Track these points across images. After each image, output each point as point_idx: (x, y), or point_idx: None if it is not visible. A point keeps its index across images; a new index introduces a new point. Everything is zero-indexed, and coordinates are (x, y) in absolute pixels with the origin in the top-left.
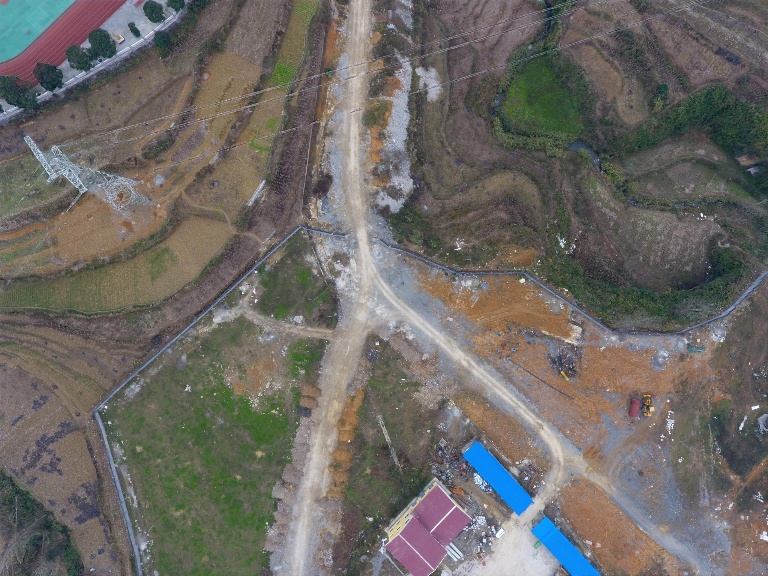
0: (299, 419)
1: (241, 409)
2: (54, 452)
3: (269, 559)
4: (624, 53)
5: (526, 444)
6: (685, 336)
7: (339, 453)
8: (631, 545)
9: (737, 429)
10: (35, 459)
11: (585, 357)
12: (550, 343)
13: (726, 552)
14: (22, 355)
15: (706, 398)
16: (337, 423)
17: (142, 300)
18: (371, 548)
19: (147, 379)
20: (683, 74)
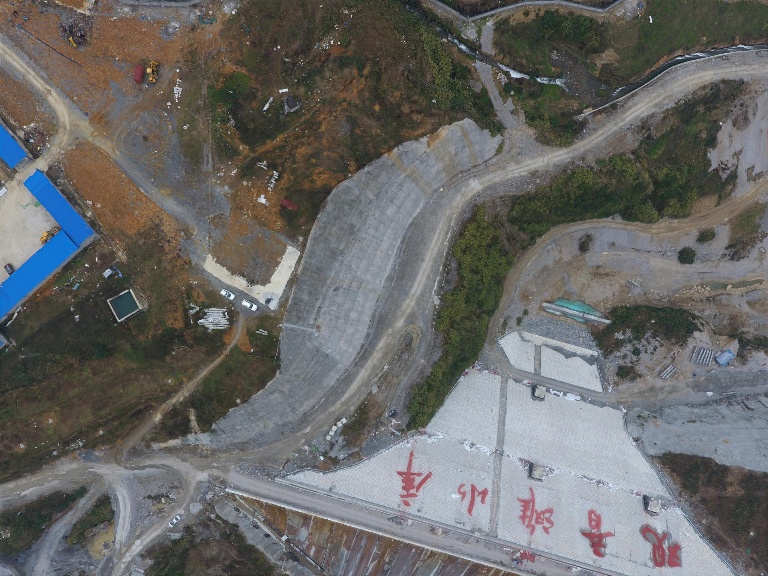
0: None
1: None
2: None
3: None
4: None
5: (34, 109)
6: (197, 8)
7: None
8: (131, 206)
9: (261, 109)
10: None
11: (96, 26)
12: (63, 13)
13: (225, 215)
14: None
15: (215, 68)
16: None
17: None
18: None
19: None
20: None
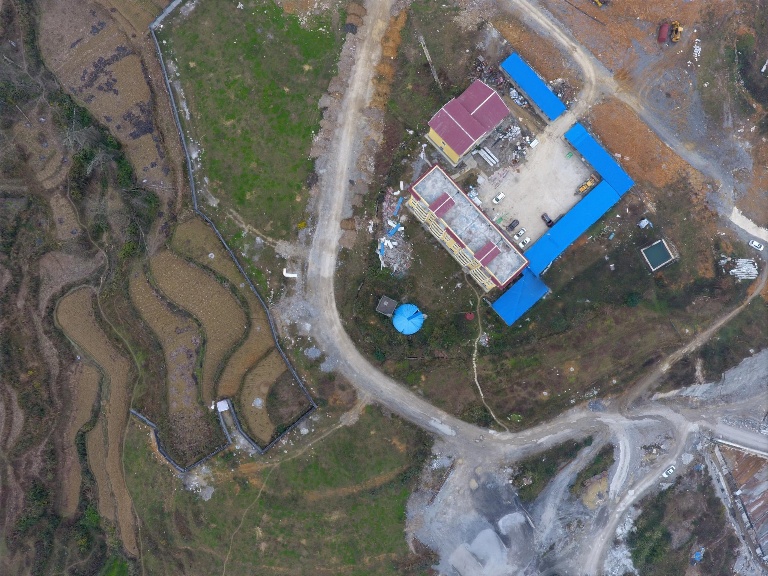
0: (345, 35)
1: (290, 26)
2: (110, 73)
3: (314, 164)
4: None
5: (560, 64)
6: None
7: (383, 65)
8: (658, 159)
9: (759, 70)
10: (92, 79)
11: None
12: None
13: (748, 169)
14: None
15: (731, 29)
16: (381, 40)
17: None
18: (412, 152)
19: None
20: None
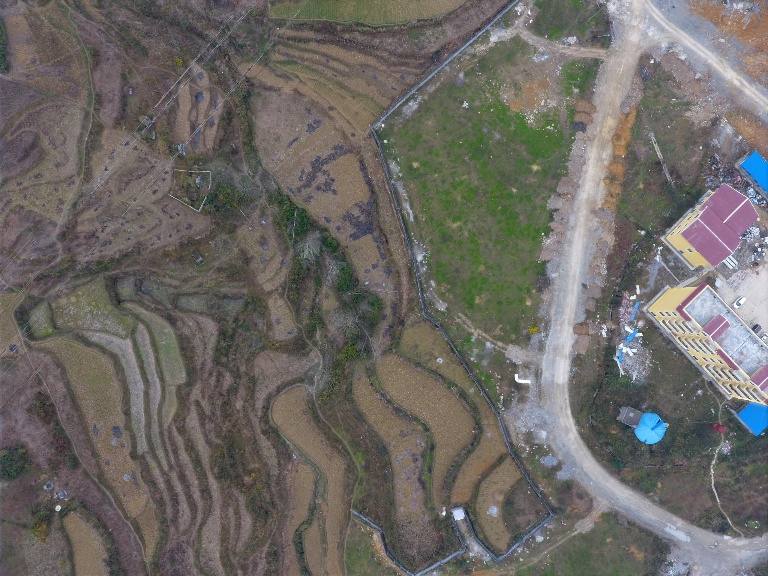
0: (575, 134)
1: (517, 125)
2: (328, 173)
3: (546, 267)
4: None
5: None
6: None
7: (615, 165)
8: None
9: None
10: (310, 179)
11: None
12: None
13: None
14: (302, 75)
15: None
16: (612, 138)
17: (426, 14)
18: (647, 255)
19: (425, 96)
20: None
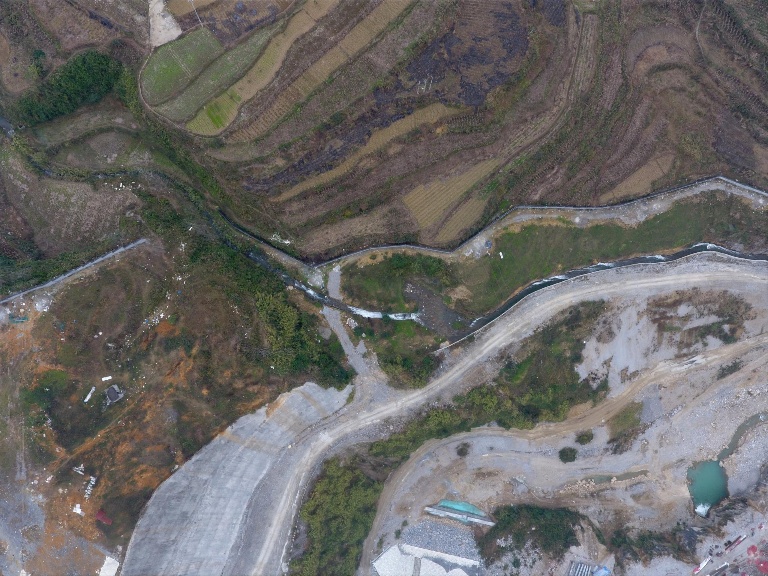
0: None
1: None
2: None
3: None
4: (3, 19)
5: None
6: (8, 306)
7: None
8: None
9: (82, 401)
10: None
11: None
12: None
13: (39, 526)
14: None
15: (27, 369)
16: None
17: None
18: None
19: None
20: (55, 39)
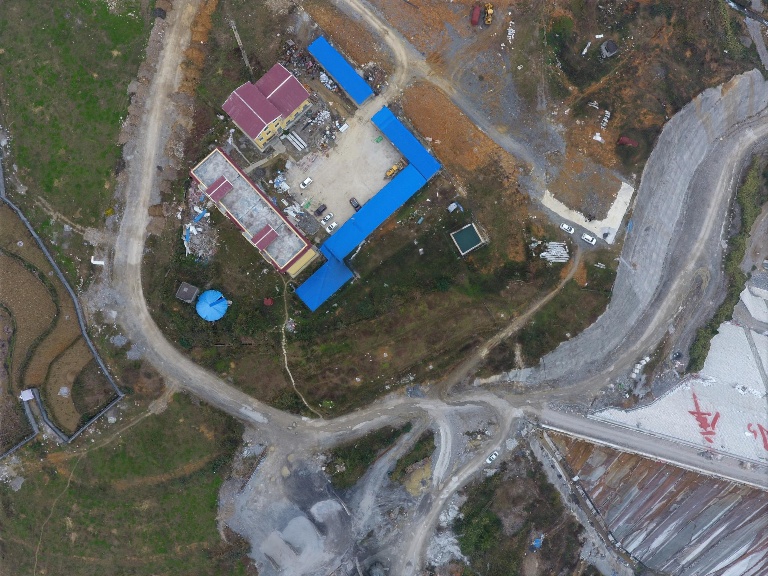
0: (154, 20)
1: (99, 11)
2: None
3: (122, 150)
4: None
5: (371, 48)
6: None
7: (191, 50)
8: (469, 143)
9: (580, 53)
10: None
11: None
12: None
13: (561, 152)
14: None
15: (546, 11)
16: (190, 25)
17: None
18: (219, 138)
19: None
20: None
